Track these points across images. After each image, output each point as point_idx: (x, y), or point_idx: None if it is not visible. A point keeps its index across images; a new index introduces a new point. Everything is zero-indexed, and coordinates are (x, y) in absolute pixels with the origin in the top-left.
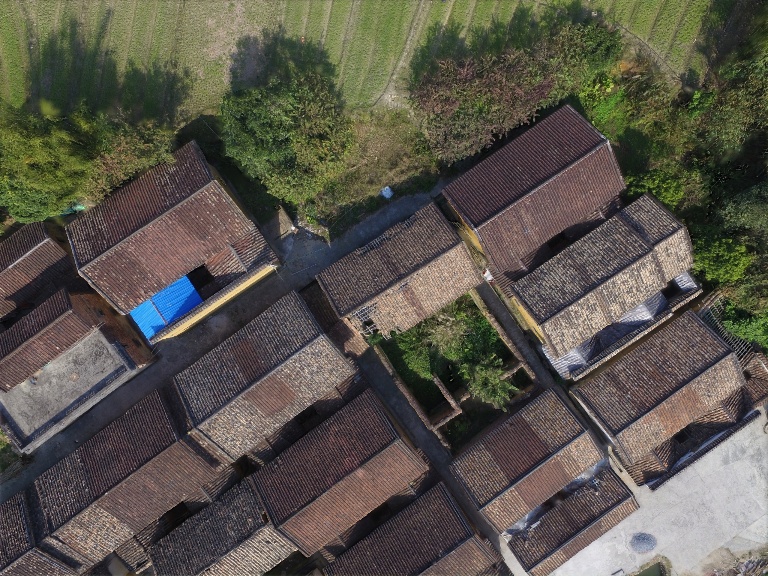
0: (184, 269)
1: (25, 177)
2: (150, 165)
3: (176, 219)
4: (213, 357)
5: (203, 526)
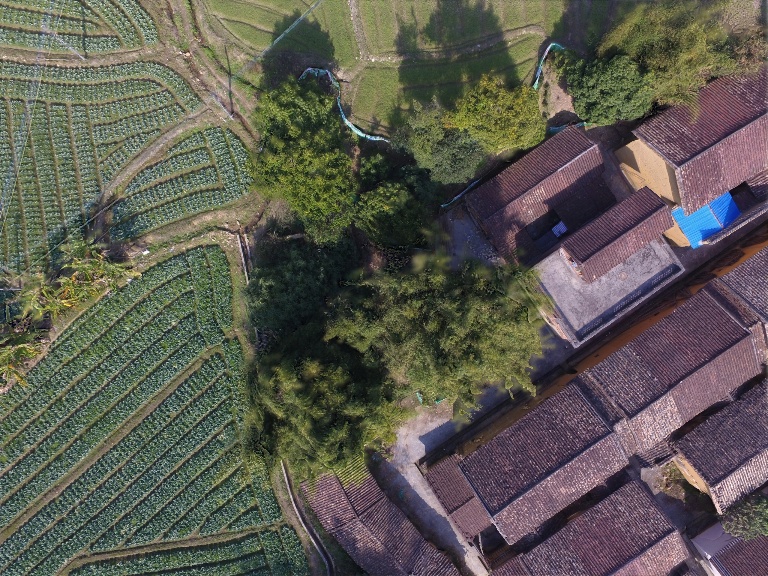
0: (747, 175)
1: (675, 71)
2: (713, 76)
3: (764, 124)
4: (759, 261)
5: (732, 422)
